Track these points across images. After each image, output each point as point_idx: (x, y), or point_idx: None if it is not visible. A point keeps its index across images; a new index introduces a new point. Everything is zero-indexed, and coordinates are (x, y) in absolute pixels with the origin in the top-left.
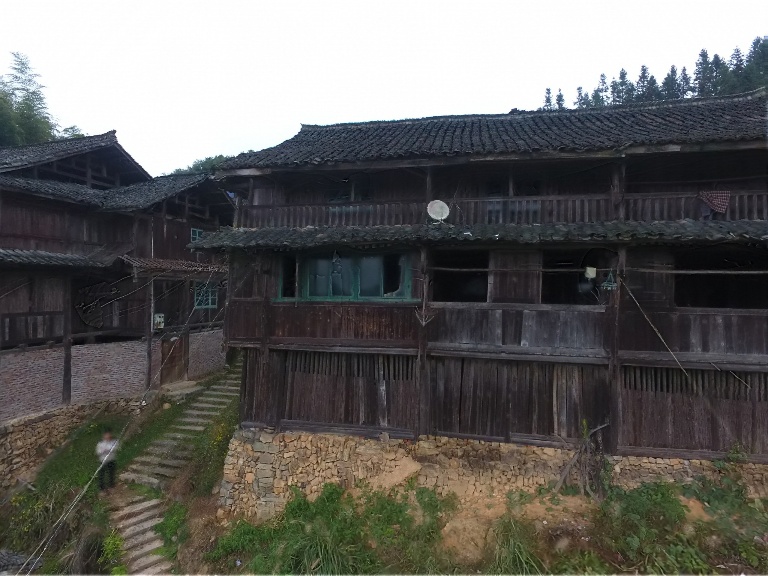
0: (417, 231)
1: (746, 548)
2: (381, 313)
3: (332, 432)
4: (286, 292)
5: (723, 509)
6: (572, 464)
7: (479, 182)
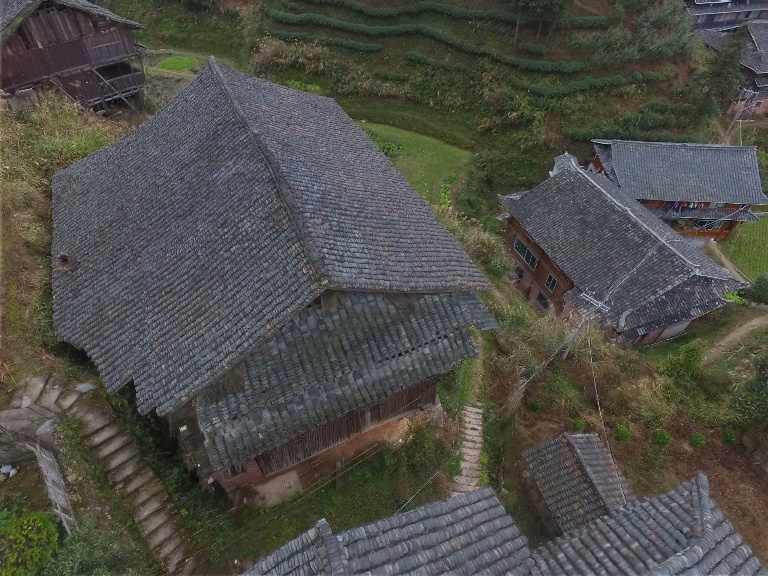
0: None
1: None
2: None
3: None
4: None
5: None
6: None
7: None
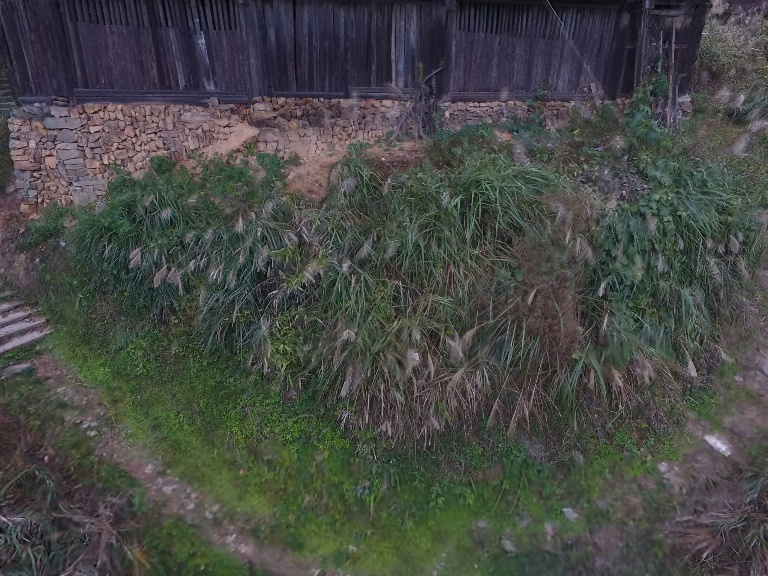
0: None
1: (541, 150)
2: None
3: (147, 101)
4: None
5: (527, 135)
6: (408, 112)
7: None
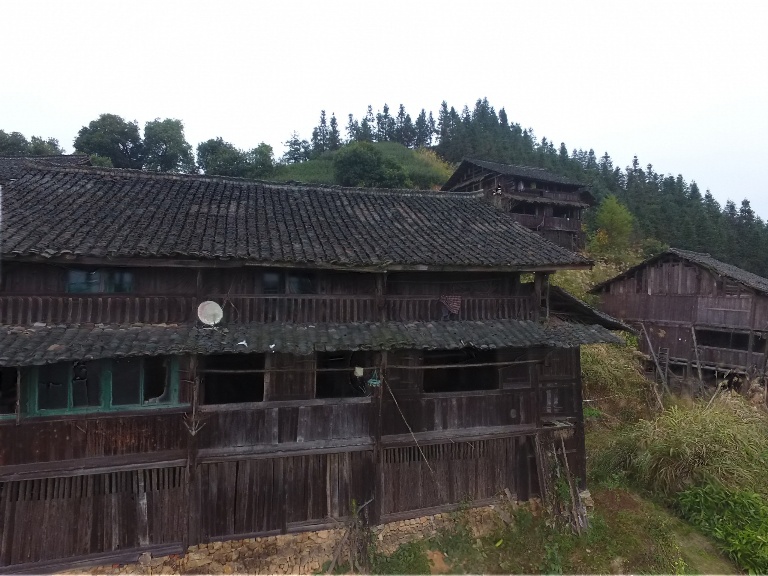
0: (185, 338)
1: None
2: (141, 423)
3: (73, 568)
4: (1, 407)
5: (456, 556)
6: (343, 543)
7: (255, 273)
